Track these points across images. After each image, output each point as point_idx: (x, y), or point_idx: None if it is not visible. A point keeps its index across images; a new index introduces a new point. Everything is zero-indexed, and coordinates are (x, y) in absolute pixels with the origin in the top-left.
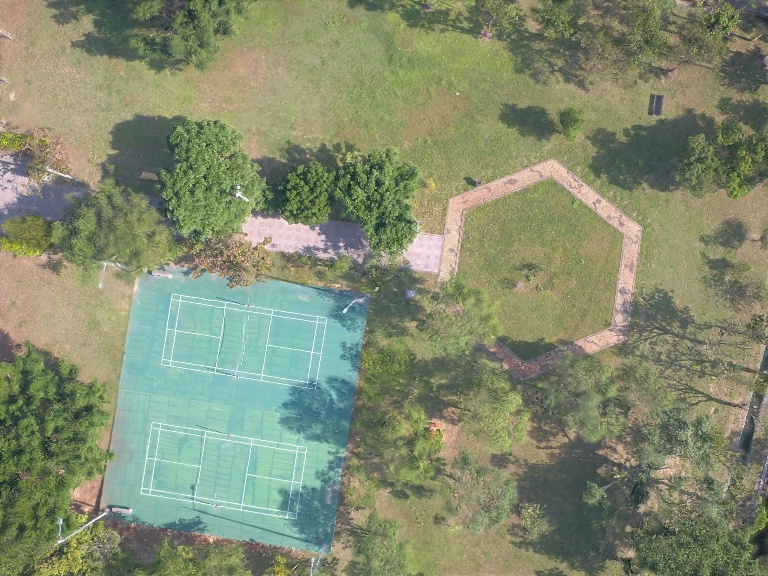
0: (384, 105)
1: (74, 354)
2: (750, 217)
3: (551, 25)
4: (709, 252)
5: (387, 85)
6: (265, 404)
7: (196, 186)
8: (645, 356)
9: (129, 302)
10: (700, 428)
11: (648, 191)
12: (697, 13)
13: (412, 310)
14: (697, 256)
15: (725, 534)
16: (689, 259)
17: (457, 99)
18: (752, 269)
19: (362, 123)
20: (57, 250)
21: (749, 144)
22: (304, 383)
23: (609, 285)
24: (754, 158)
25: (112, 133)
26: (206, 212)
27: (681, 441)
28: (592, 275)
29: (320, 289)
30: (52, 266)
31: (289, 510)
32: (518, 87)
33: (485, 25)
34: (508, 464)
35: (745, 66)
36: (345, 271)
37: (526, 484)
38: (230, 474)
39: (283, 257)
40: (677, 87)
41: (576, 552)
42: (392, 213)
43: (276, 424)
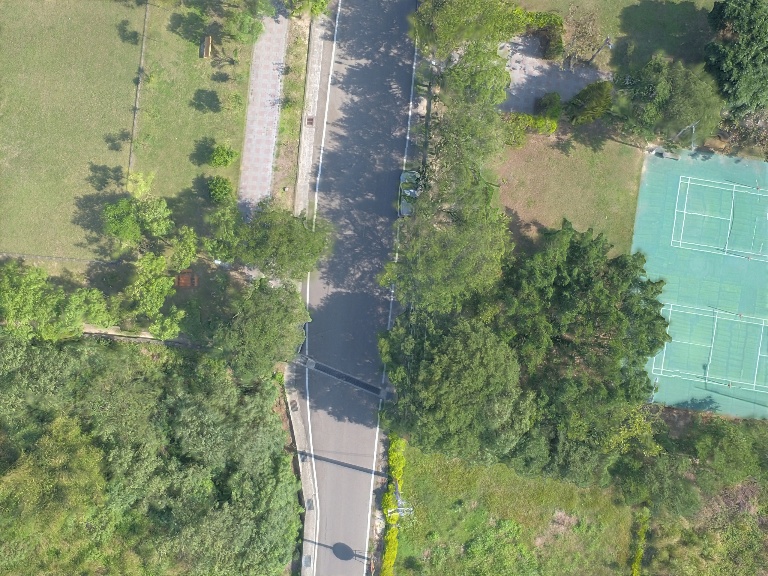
0: None
1: None
2: None
3: None
4: None
5: None
6: None
7: (756, 58)
8: None
9: (637, 184)
10: None
11: None
12: None
13: None
14: None
15: None
16: None
17: None
18: None
19: None
20: (567, 131)
21: None
22: None
23: None
24: None
25: (620, 17)
26: (761, 85)
27: None
28: None
29: None
30: (561, 147)
31: None
32: None
33: None
34: None
35: None
36: None
37: None
38: (743, 354)
39: None
40: None
41: None
42: None
43: None
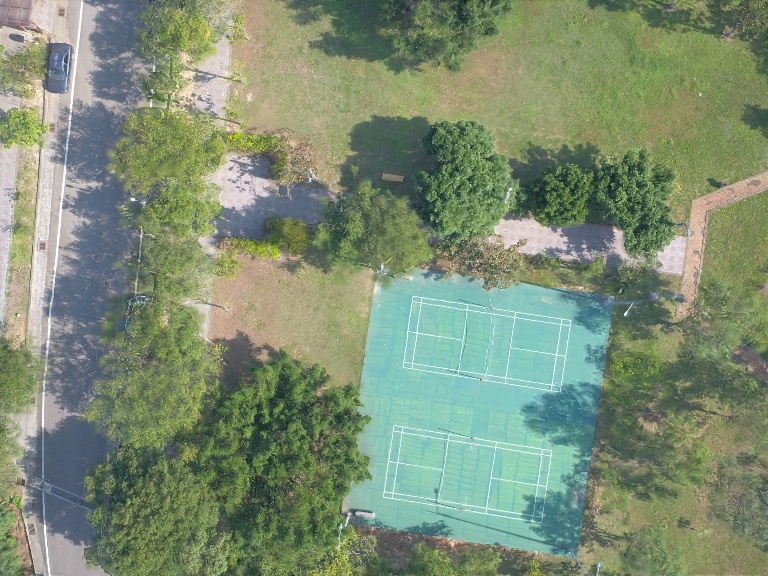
0: (626, 106)
1: (314, 357)
2: None
3: None
4: None
5: (629, 86)
6: (509, 407)
7: (461, 188)
8: None
9: (369, 304)
10: None
11: None
12: None
13: (656, 312)
14: None
15: None
16: None
17: (699, 100)
18: None
19: (604, 124)
20: (296, 252)
21: None
22: (549, 386)
23: None
24: None
25: (351, 134)
26: (469, 214)
27: None
28: None
29: (564, 291)
30: (291, 268)
31: (534, 514)
32: (761, 88)
33: (727, 25)
34: (753, 467)
35: None
36: None
37: None
38: (474, 477)
39: (525, 259)
40: None
41: None
42: (656, 215)
43: (521, 427)
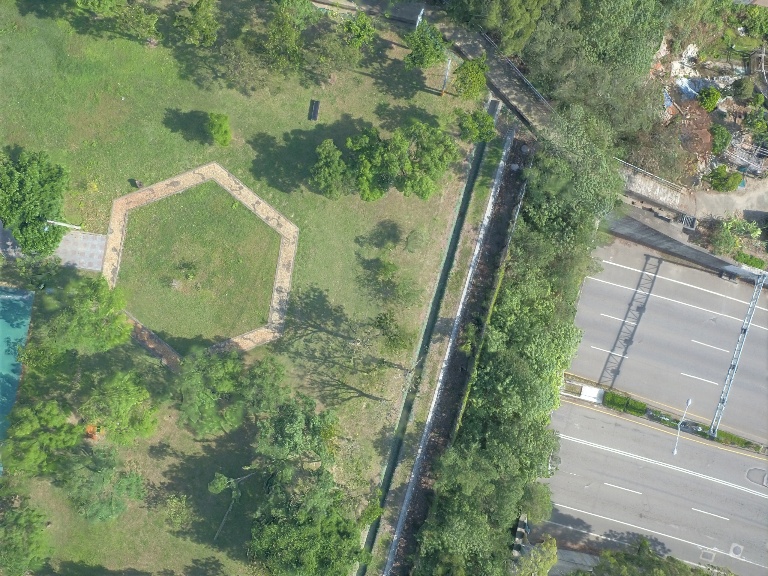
0: (52, 109)
1: None
2: (405, 219)
3: (188, 33)
4: (364, 253)
5: (56, 90)
6: None
7: None
8: (299, 353)
9: None
10: (312, 422)
11: (306, 193)
12: None
13: None
14: (352, 256)
15: (332, 524)
16: (344, 259)
17: (123, 104)
18: (405, 269)
19: (31, 126)
20: None
21: None
22: None
23: (266, 284)
24: (372, 162)
25: None
26: None
27: (290, 434)
28: (250, 274)
29: None
30: None
31: None
32: (182, 92)
33: None
34: (166, 456)
35: (403, 73)
36: (12, 269)
37: (183, 475)
38: None
39: None
40: (337, 93)
41: (232, 542)
42: (30, 213)
43: None
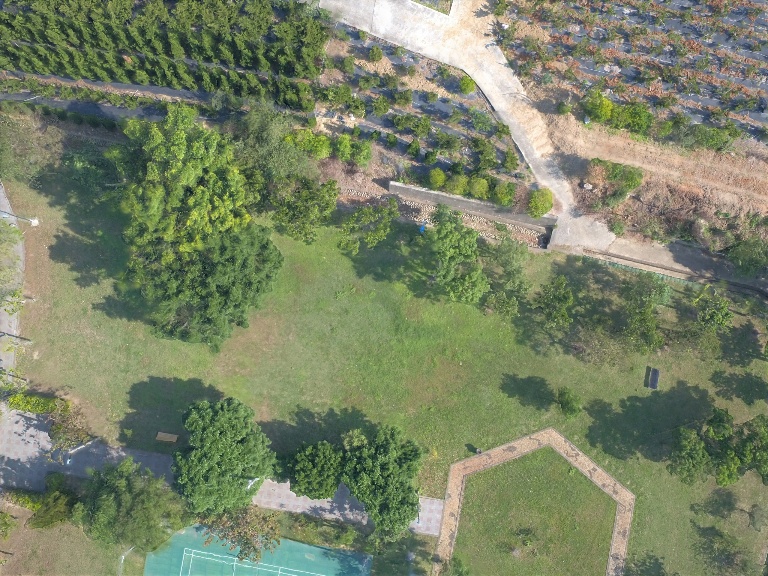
0: (390, 373)
1: None
2: (740, 487)
3: (551, 320)
4: (699, 521)
5: (393, 353)
6: None
7: (210, 472)
8: None
9: (144, 554)
10: None
11: (642, 461)
12: (694, 288)
13: (413, 571)
14: (687, 524)
15: None
16: (680, 527)
17: (460, 368)
18: (740, 538)
19: (369, 389)
20: None
21: (739, 435)
22: None
23: (602, 551)
24: (743, 460)
25: (130, 393)
26: (219, 495)
27: None
28: (586, 541)
29: (326, 549)
30: None
31: None
32: (519, 358)
33: None
34: None
35: (739, 341)
36: None
37: None
38: None
39: (291, 516)
40: (673, 360)
41: None
42: (395, 500)
43: None
